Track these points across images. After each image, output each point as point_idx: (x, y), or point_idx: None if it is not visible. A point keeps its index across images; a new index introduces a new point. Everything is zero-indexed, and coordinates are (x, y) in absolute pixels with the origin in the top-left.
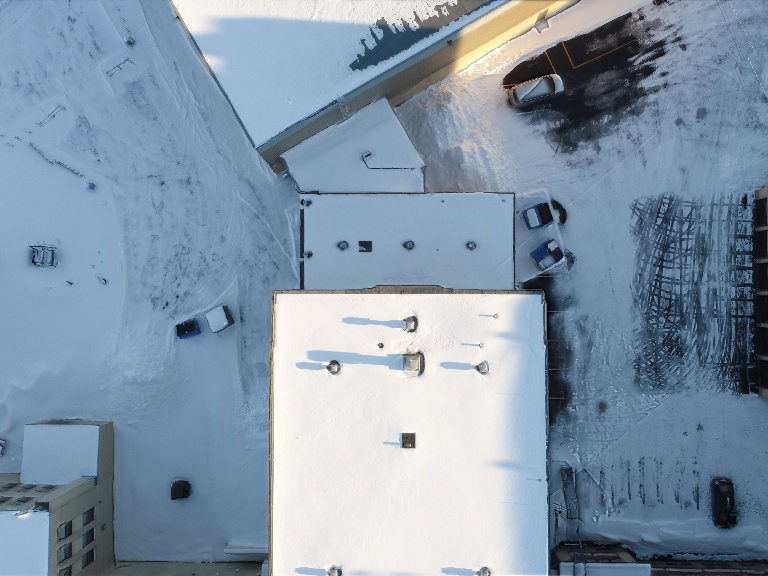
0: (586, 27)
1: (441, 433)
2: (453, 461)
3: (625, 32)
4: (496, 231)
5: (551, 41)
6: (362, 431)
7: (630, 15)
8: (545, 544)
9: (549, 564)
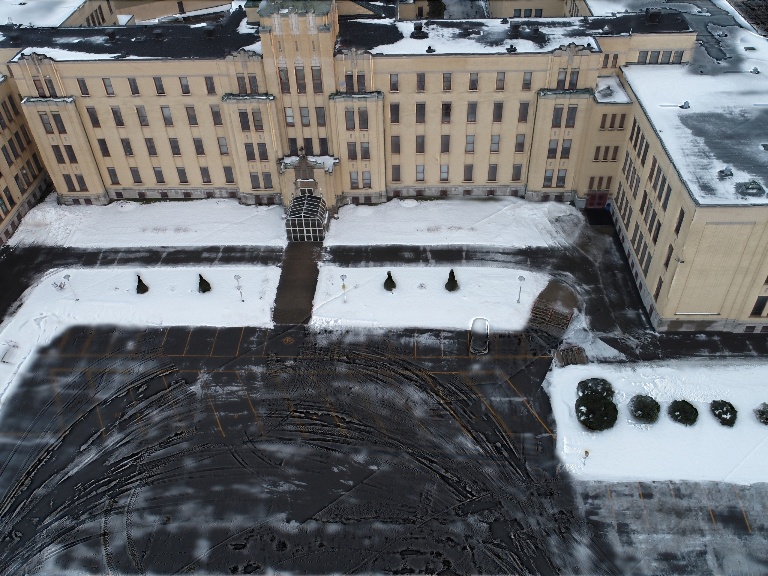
0: (202, 13)
1: (39, 3)
2: (39, 7)
3: (219, 14)
4: (120, 21)
5: (185, 15)
6: (4, 3)
7: (223, 11)
8: (65, 18)
9: (64, 22)
